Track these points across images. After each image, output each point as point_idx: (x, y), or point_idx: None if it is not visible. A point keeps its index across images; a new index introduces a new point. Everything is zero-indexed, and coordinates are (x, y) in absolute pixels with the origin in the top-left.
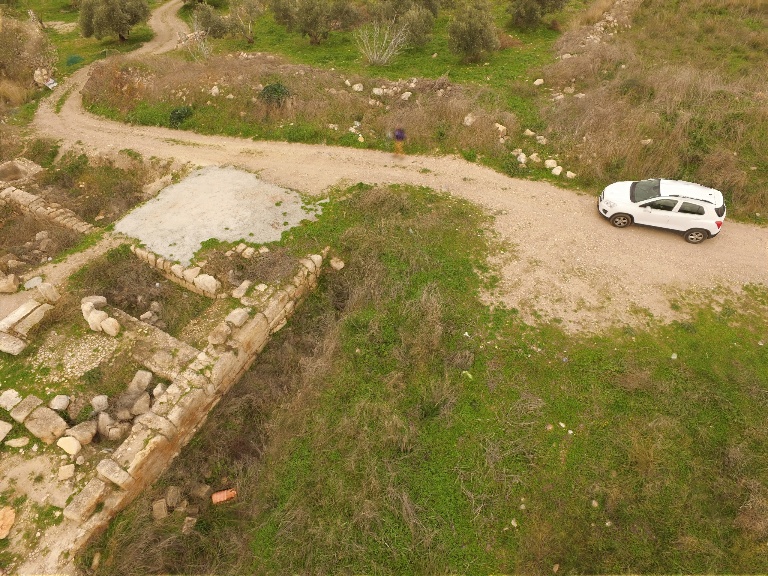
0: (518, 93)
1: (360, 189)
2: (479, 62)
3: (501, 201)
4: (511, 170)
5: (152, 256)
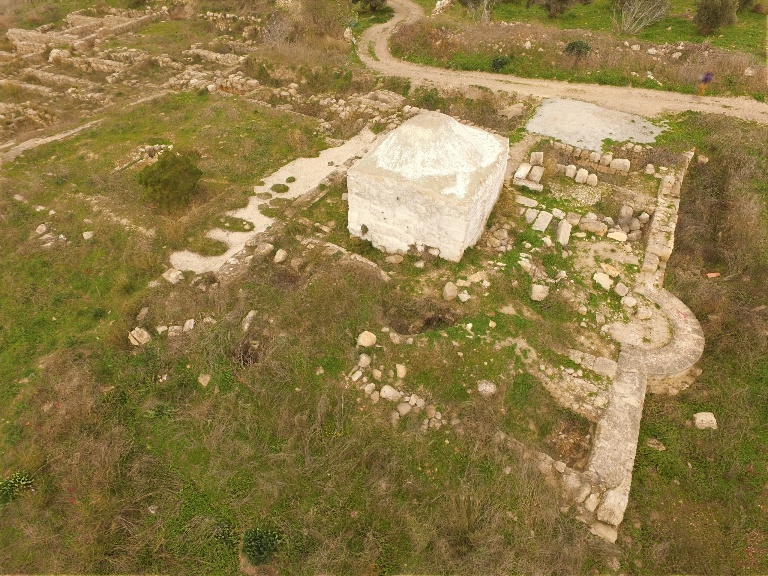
0: (767, 57)
1: (691, 114)
2: (713, 34)
3: None
4: None
5: (571, 147)
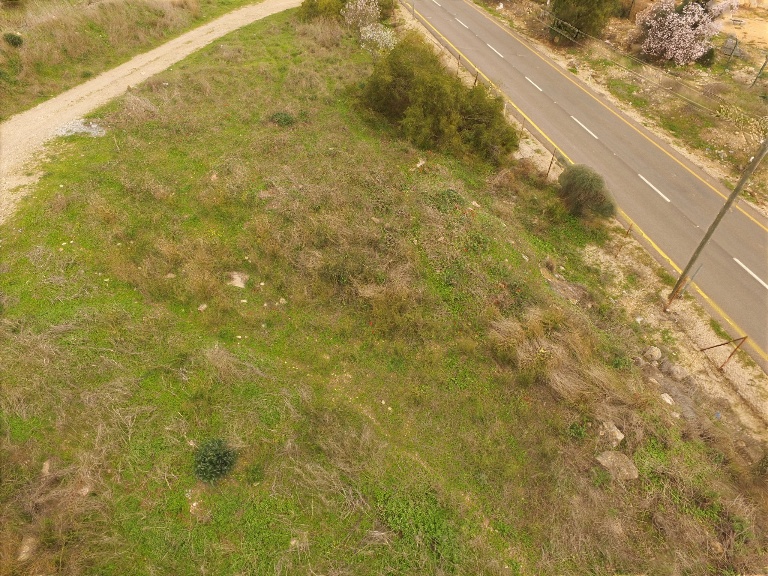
0: None
1: None
2: None
3: None
4: None
5: None
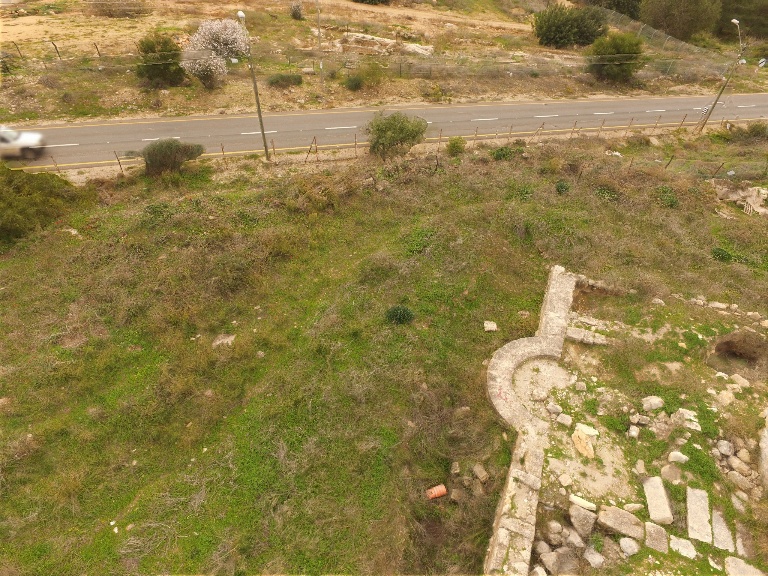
0: None
1: None
2: None
3: None
4: None
5: None
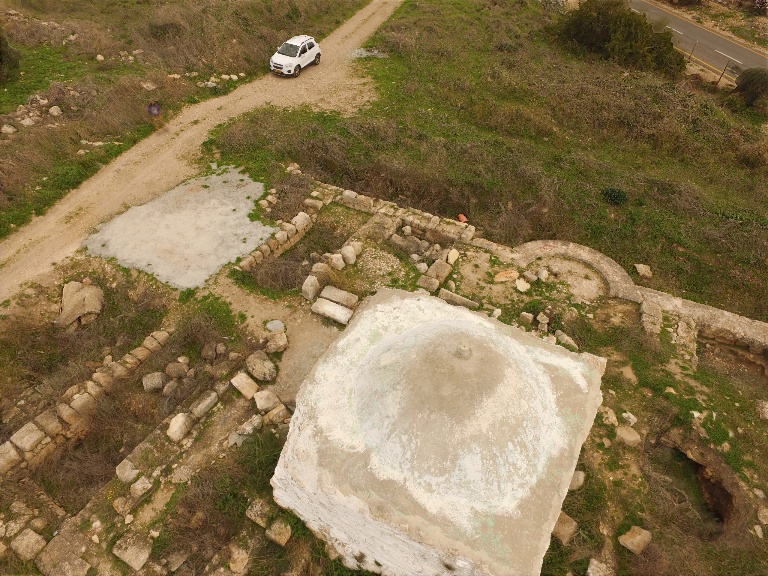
0: (109, 68)
1: (212, 144)
2: (12, 75)
3: (254, 101)
4: (222, 91)
5: (257, 252)
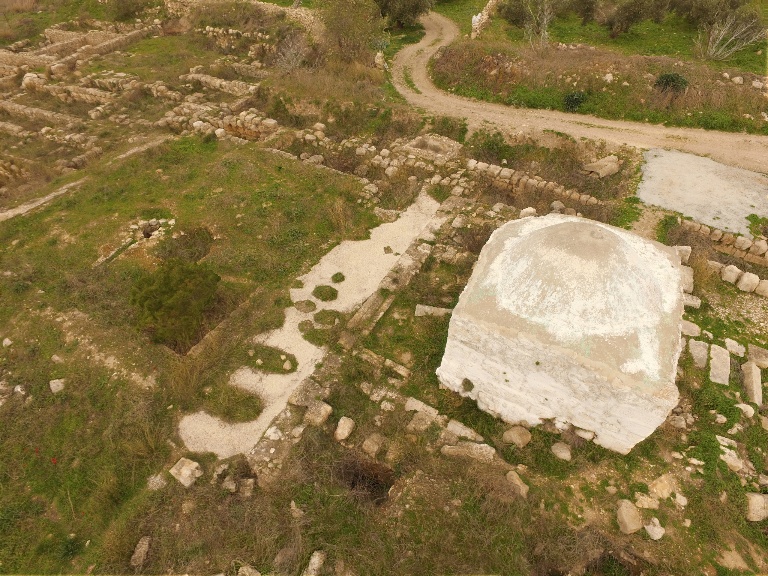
0: None
1: None
2: None
3: None
4: None
5: (708, 228)
